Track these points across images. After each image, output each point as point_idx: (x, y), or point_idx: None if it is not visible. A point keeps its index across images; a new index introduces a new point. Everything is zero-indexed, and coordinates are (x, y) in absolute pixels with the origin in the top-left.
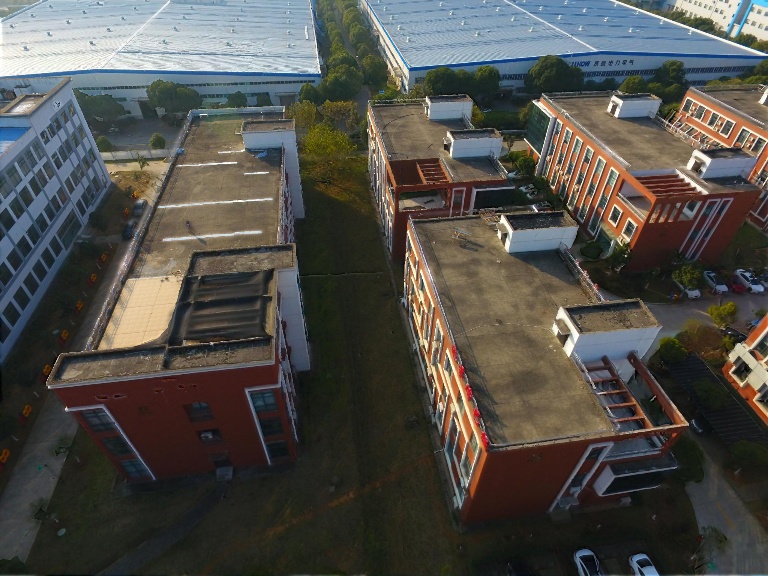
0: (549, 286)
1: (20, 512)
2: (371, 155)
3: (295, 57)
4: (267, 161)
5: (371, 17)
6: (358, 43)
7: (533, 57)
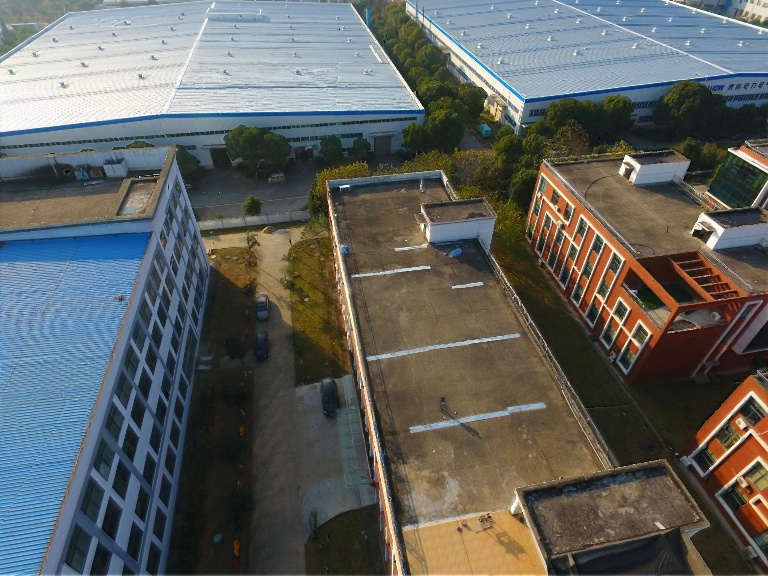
0: None
1: None
2: (543, 225)
3: (381, 87)
4: (469, 263)
5: (432, 31)
6: (431, 64)
7: (664, 82)
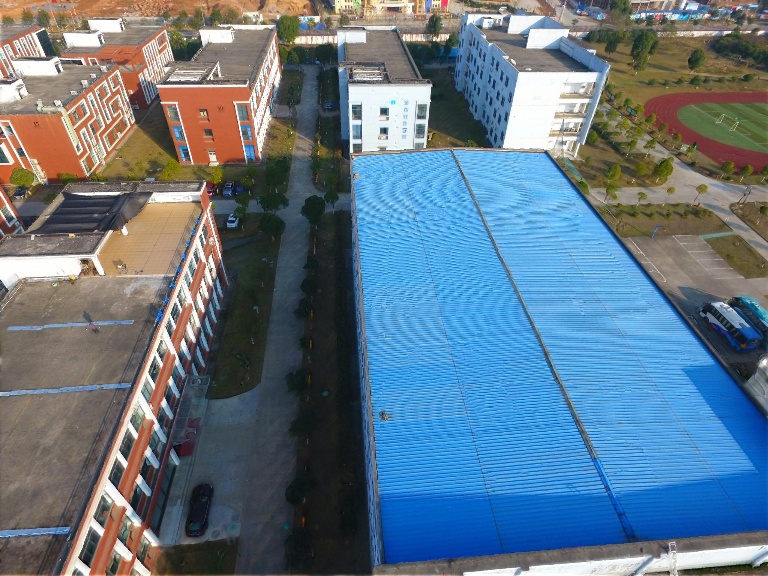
0: None
1: (291, 268)
2: None
3: None
4: None
5: None
6: None
7: None
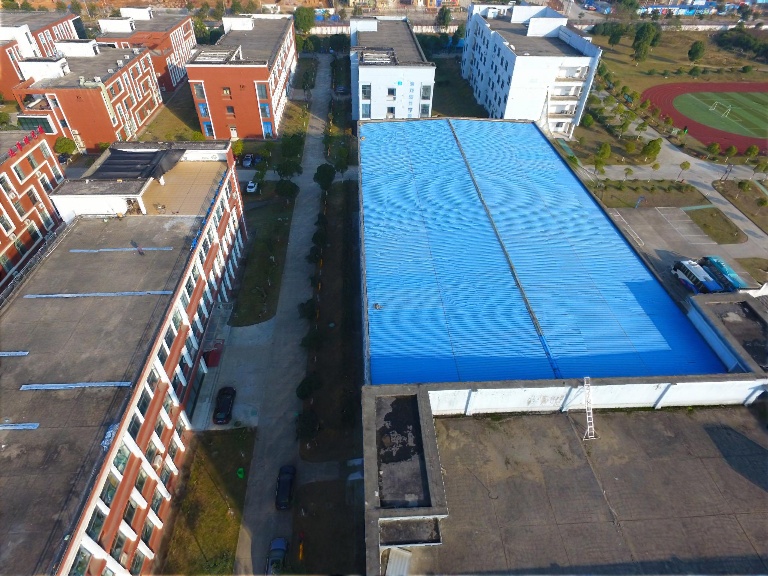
0: None
1: (304, 226)
2: None
3: None
4: None
5: None
6: None
7: None
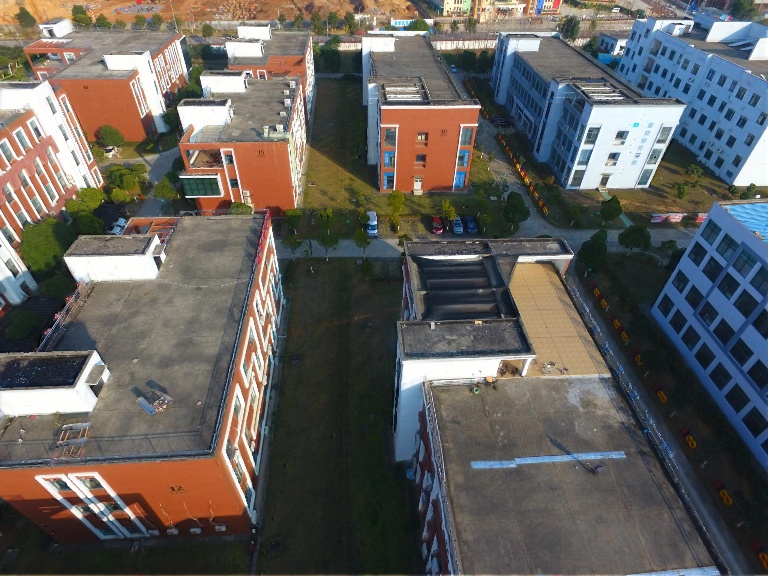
0: (109, 322)
1: None
2: None
3: None
4: None
5: None
6: None
7: None
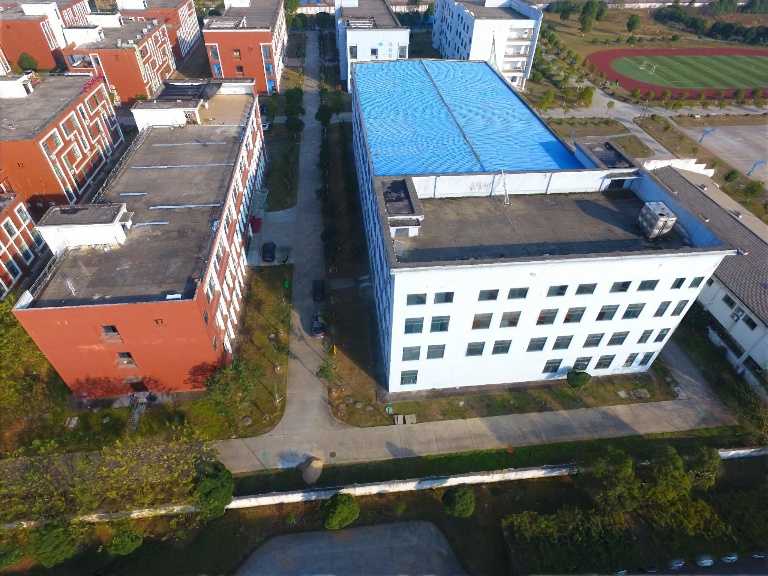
0: None
1: (310, 152)
2: None
3: None
4: None
5: None
6: None
7: None
